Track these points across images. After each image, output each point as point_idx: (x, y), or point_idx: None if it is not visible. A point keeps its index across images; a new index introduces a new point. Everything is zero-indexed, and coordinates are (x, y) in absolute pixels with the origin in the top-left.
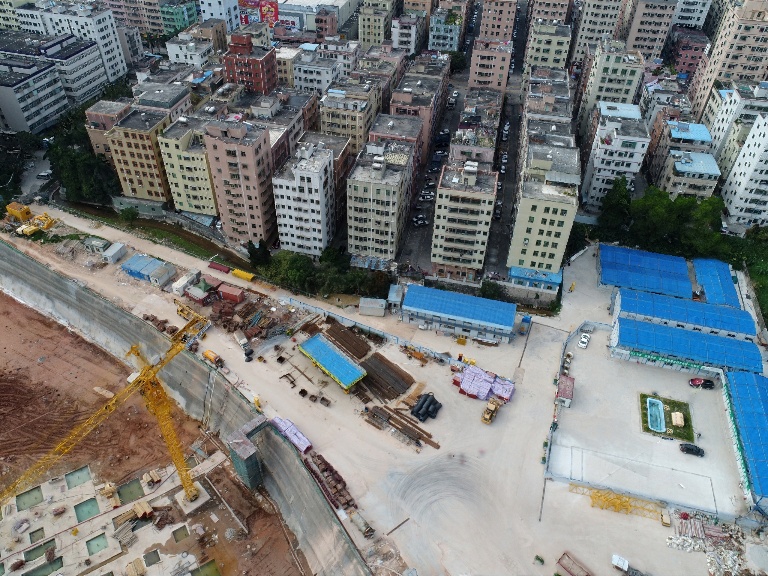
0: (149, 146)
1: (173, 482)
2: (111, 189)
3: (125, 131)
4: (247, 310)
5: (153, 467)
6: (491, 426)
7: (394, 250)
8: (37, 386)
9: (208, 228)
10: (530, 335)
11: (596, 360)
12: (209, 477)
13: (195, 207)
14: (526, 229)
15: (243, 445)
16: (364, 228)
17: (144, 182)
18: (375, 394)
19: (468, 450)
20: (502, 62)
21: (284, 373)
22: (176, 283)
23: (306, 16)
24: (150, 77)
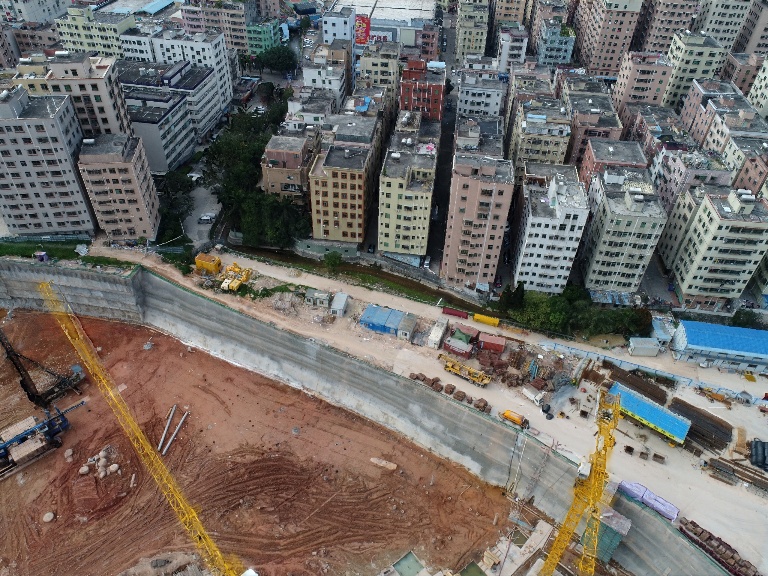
0: (359, 185)
1: (513, 562)
2: (299, 232)
3: (335, 171)
4: (517, 360)
5: (483, 546)
6: None
7: (639, 283)
8: (308, 463)
9: (418, 269)
10: None
11: None
12: (548, 552)
13: (402, 247)
14: None
15: (615, 519)
16: (612, 262)
17: (341, 223)
18: (702, 445)
19: None
20: (662, 76)
21: (595, 429)
22: (432, 336)
23: (400, 31)
24: (304, 106)
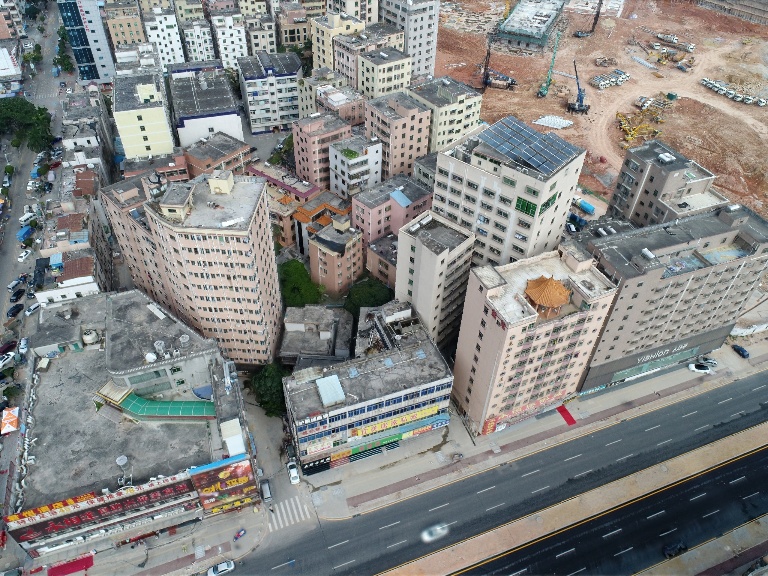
0: None
1: None
2: None
3: None
4: None
5: None
6: None
7: None
8: None
9: None
10: None
11: None
12: None
13: None
14: None
15: None
16: None
17: None
18: None
19: None
20: None
21: None
22: None
23: None
24: None
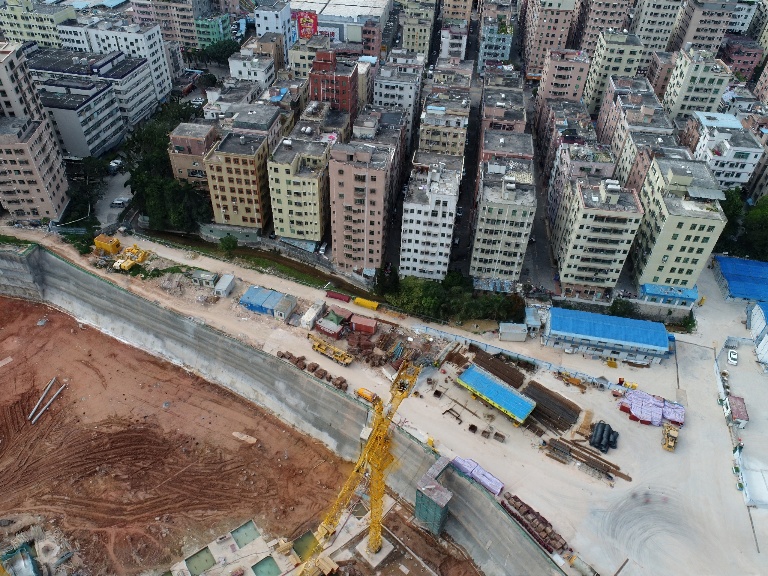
0: (252, 171)
1: (348, 532)
2: (201, 216)
3: (227, 156)
4: (385, 342)
5: (322, 517)
6: (675, 453)
7: (520, 271)
8: (171, 435)
9: (312, 254)
10: (677, 354)
11: (751, 377)
12: (385, 524)
13: (297, 233)
14: (667, 246)
15: (437, 491)
16: (491, 250)
17: (240, 208)
18: (546, 426)
19: (661, 481)
20: (580, 73)
21: (445, 408)
22: (305, 316)
23: (346, 27)
24: (222, 96)
